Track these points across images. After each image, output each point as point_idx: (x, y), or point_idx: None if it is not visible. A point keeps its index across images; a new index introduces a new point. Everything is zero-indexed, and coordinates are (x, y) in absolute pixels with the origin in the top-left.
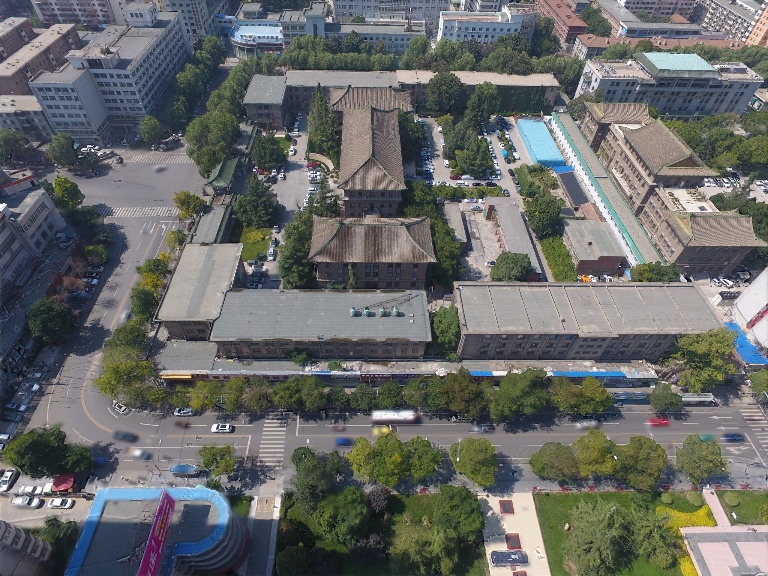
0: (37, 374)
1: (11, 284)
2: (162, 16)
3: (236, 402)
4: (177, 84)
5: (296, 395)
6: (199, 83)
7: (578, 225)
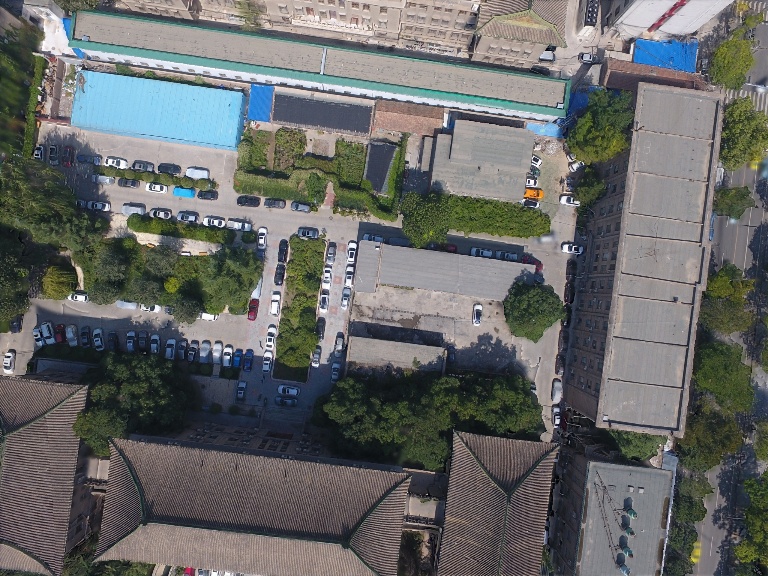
0: None
1: None
2: None
3: None
4: None
5: None
6: None
7: (448, 167)
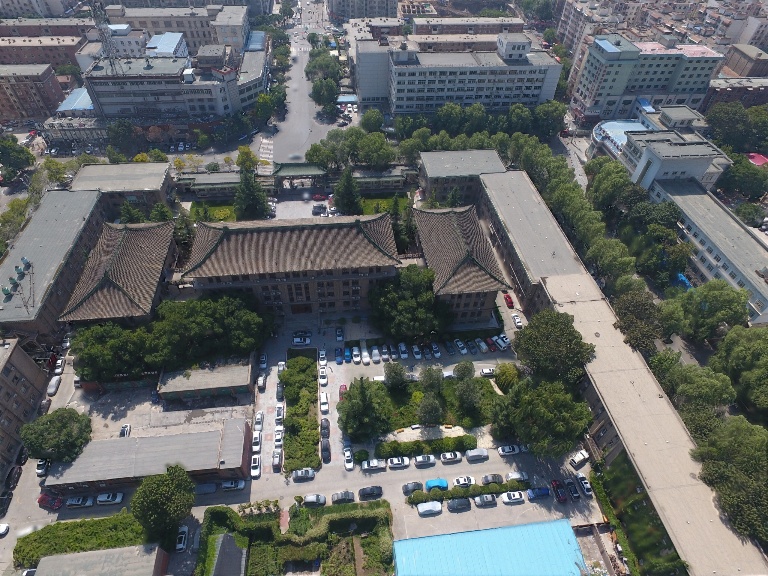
0: (97, 149)
1: (161, 113)
2: (539, 59)
3: (2, 224)
4: (438, 108)
5: None
6: (466, 124)
7: (134, 575)
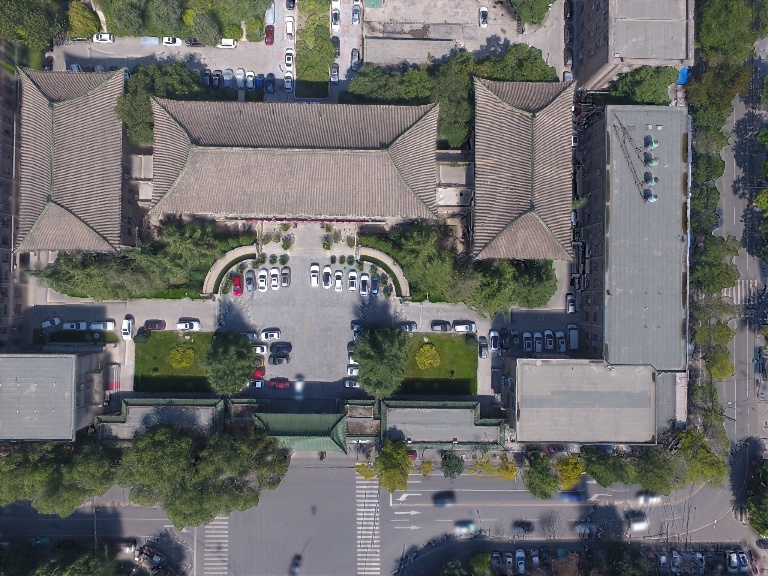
0: (663, 560)
1: None
2: None
3: None
4: None
5: (730, 265)
6: None
7: None
